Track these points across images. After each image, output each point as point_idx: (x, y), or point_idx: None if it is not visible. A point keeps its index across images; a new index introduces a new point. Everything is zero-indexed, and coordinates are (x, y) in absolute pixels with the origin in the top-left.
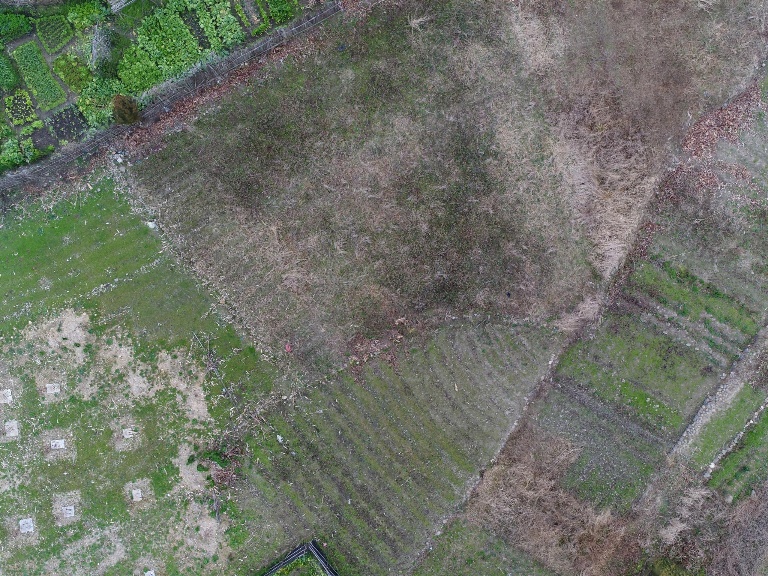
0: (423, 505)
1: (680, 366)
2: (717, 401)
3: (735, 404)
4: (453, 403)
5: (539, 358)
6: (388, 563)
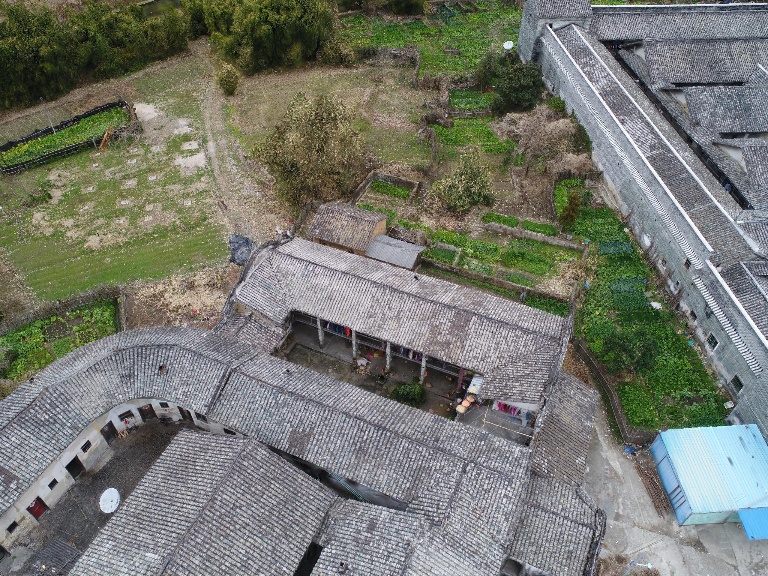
0: None
1: None
2: None
3: None
4: None
5: None
6: None
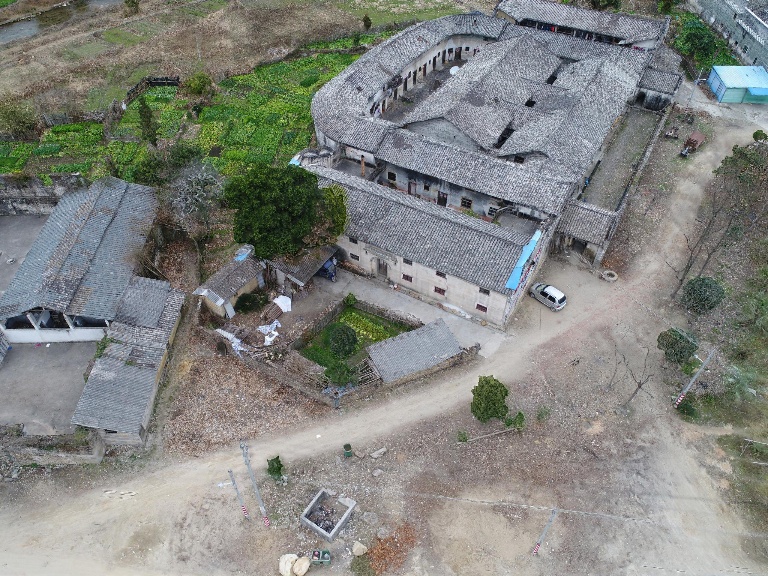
0: None
1: None
2: (198, 1)
3: (193, 0)
4: (279, 0)
5: (250, 4)
6: None
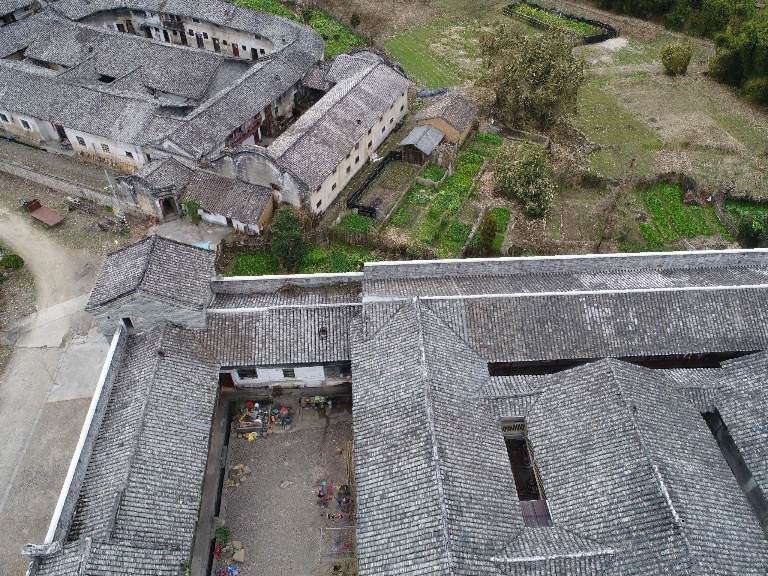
0: (483, 0)
1: None
2: None
3: None
4: None
5: None
6: (505, 4)
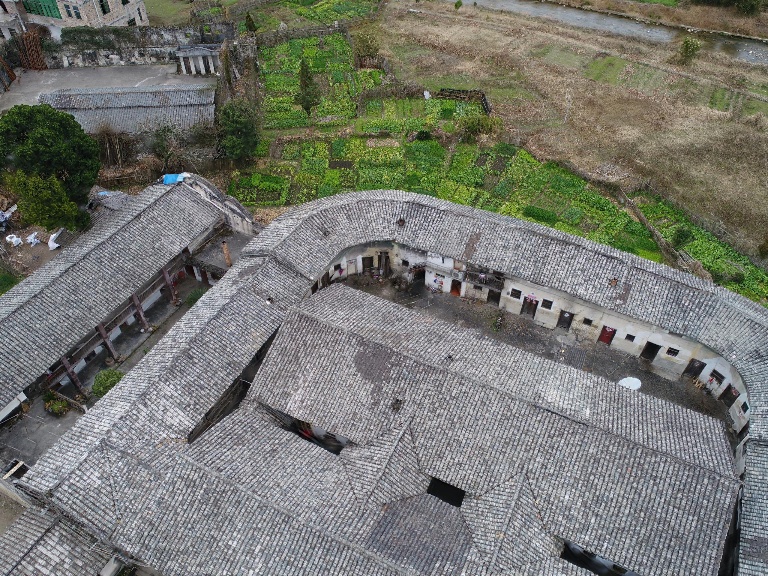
0: None
1: (753, 106)
2: (761, 97)
3: (759, 93)
4: None
5: None
6: None
